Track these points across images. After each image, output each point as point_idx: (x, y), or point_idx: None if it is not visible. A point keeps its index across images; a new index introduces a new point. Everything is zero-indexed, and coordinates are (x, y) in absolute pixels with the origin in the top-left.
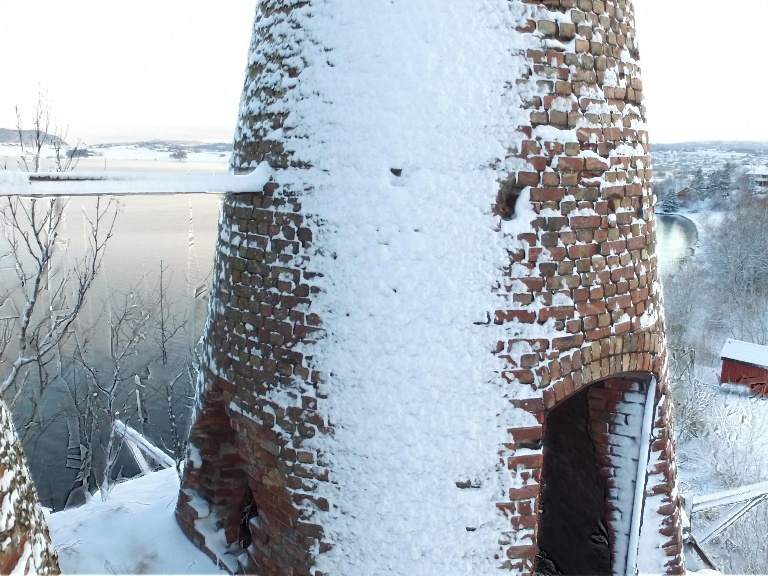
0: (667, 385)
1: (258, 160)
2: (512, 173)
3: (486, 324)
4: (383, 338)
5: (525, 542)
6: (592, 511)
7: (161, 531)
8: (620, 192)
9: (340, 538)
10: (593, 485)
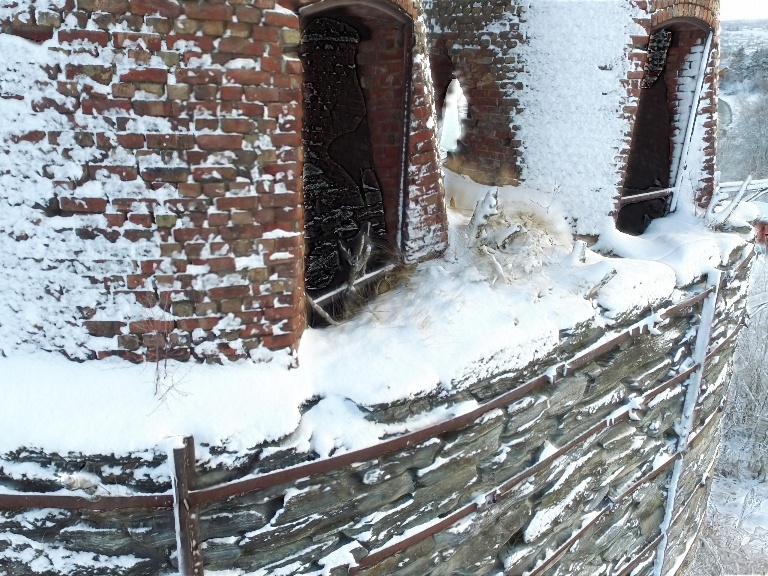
0: None
1: None
2: None
3: None
4: None
5: (633, 104)
6: (650, 178)
7: None
8: None
9: (529, 104)
10: (654, 155)
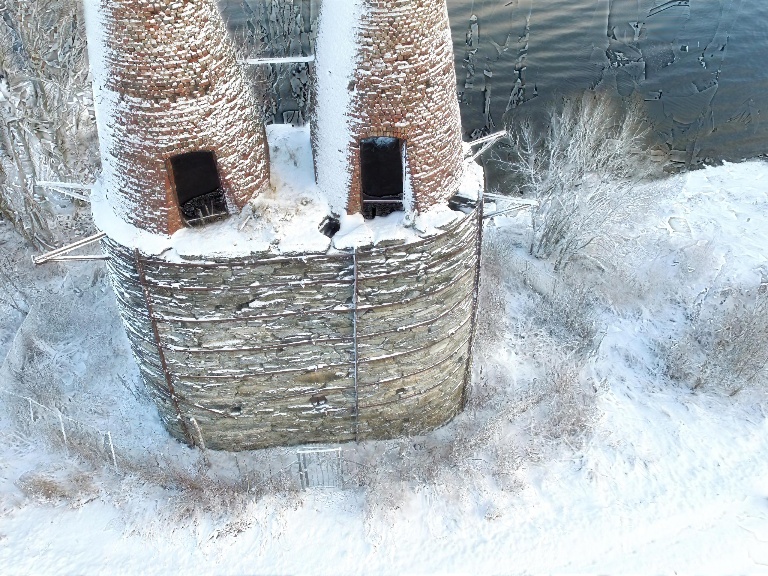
0: (418, 144)
1: None
2: (352, 80)
3: None
4: None
5: (352, 168)
6: None
7: (306, 141)
8: (388, 88)
9: (319, 154)
10: None
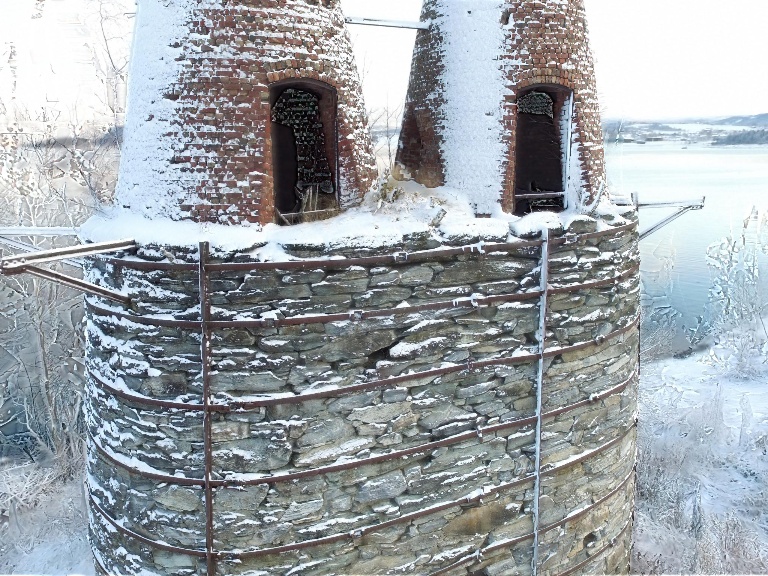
0: (584, 100)
1: (427, 18)
2: (507, 9)
3: (497, 60)
4: (464, 68)
5: (509, 135)
6: None
7: None
8: (552, 16)
9: (448, 137)
10: None
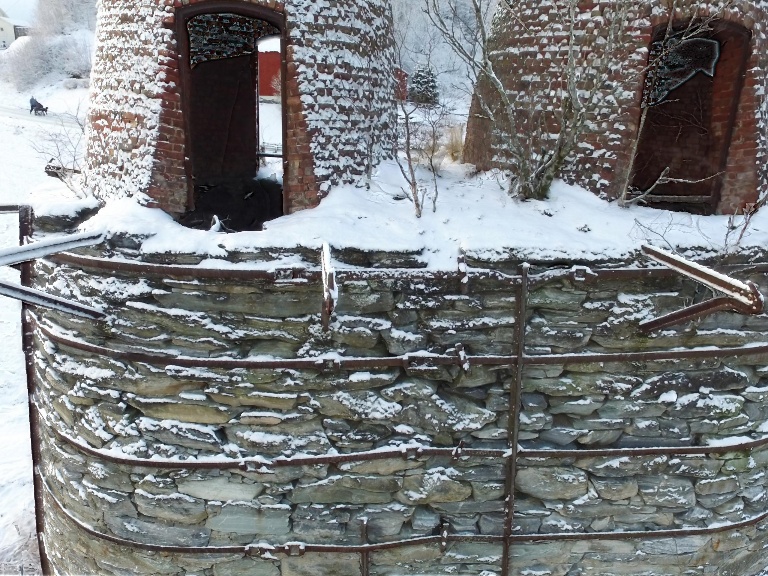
0: None
1: None
2: None
3: None
4: None
5: None
6: None
7: None
8: None
9: None
10: None
